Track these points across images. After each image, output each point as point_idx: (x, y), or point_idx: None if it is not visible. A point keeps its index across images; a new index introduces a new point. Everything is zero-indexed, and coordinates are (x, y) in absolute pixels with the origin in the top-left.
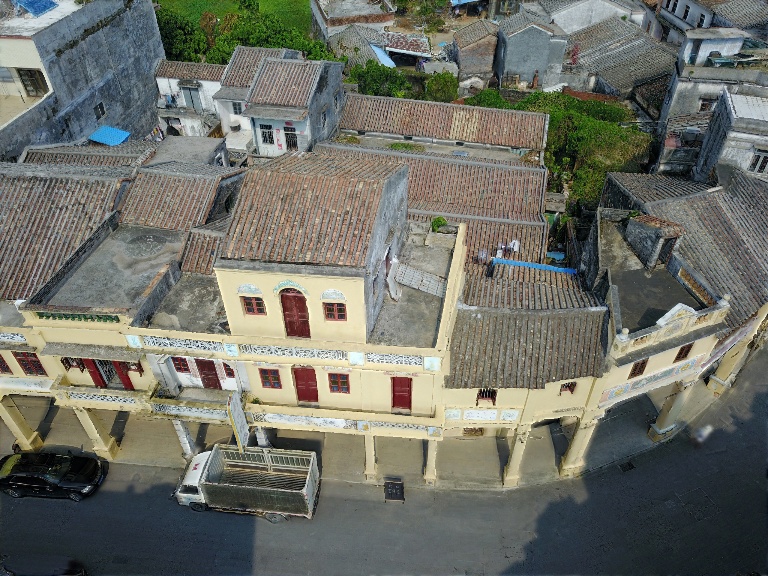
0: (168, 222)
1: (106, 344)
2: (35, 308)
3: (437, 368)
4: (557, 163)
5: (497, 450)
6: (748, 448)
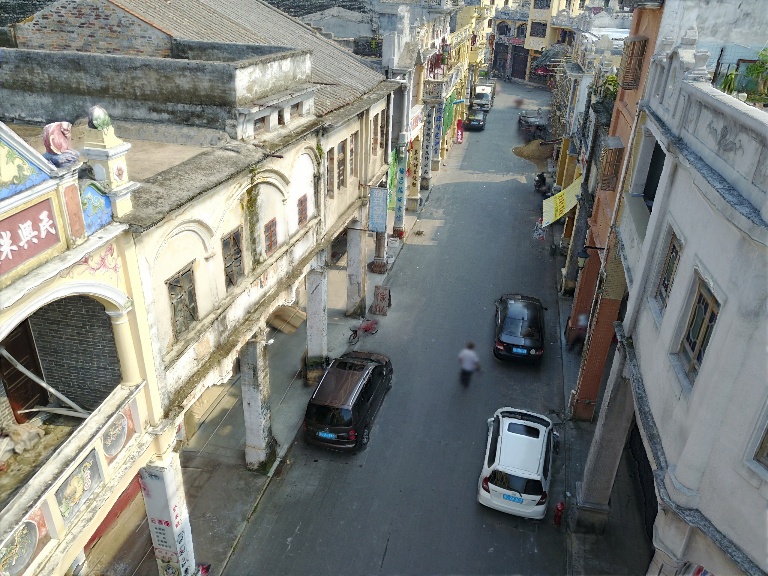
0: None
1: None
2: None
3: None
4: None
5: None
6: None
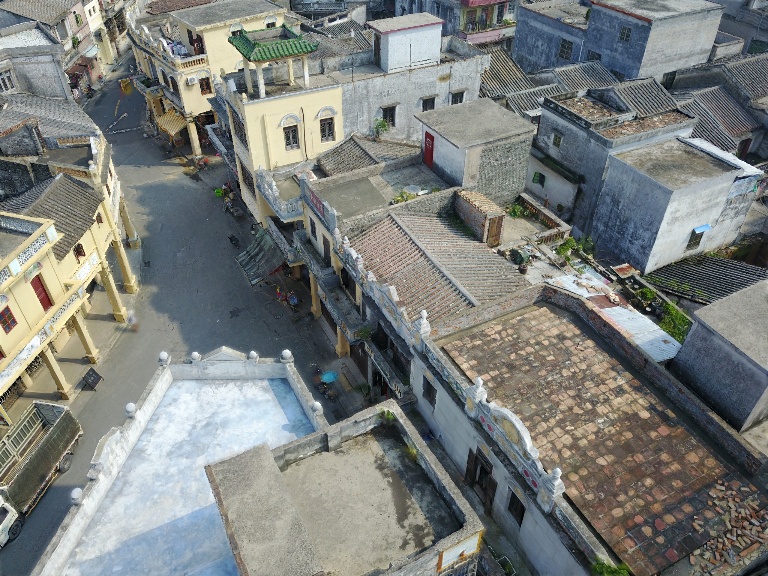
0: None
1: None
2: None
3: (55, 235)
4: None
5: (95, 320)
6: (166, 216)
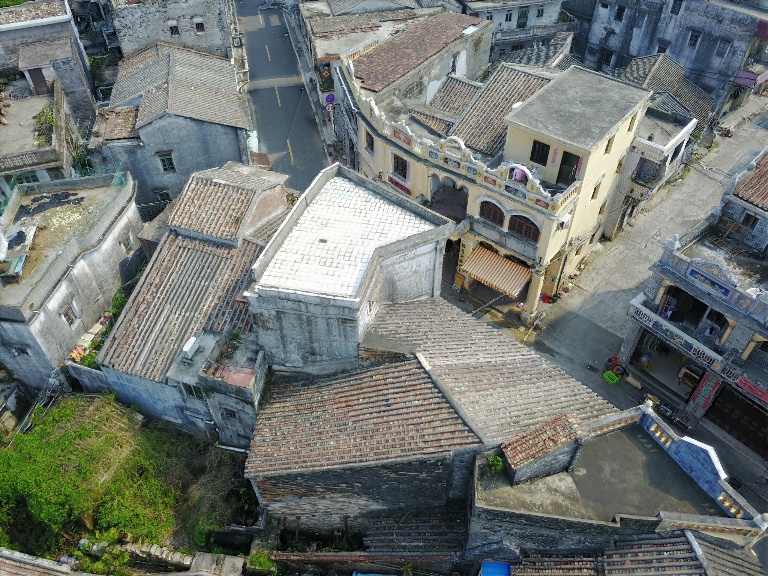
0: None
1: None
2: None
3: None
4: (38, 552)
5: None
6: None
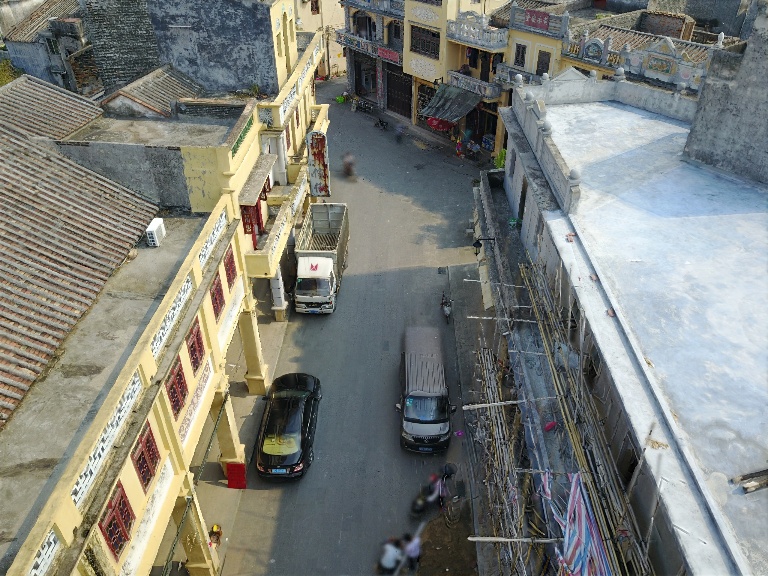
0: None
1: (251, 168)
2: (232, 139)
3: None
4: None
5: None
6: None
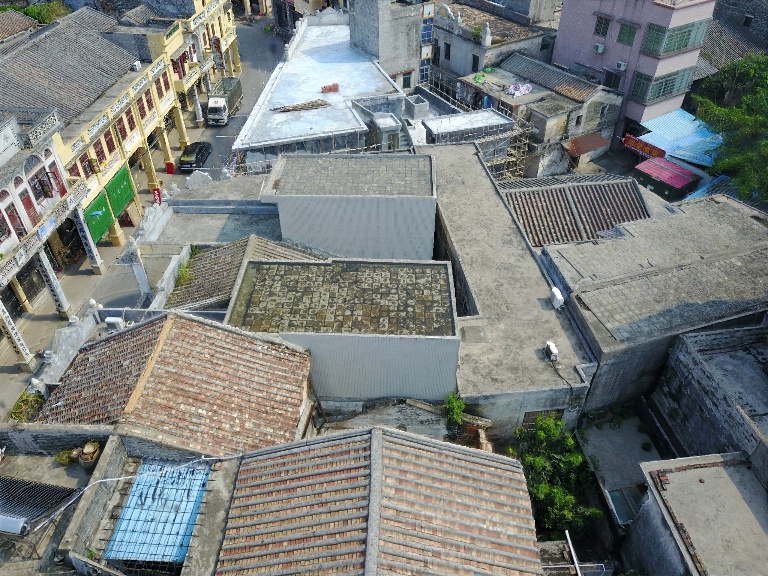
0: (106, 26)
1: (178, 47)
2: (166, 32)
3: None
4: None
5: None
6: None
